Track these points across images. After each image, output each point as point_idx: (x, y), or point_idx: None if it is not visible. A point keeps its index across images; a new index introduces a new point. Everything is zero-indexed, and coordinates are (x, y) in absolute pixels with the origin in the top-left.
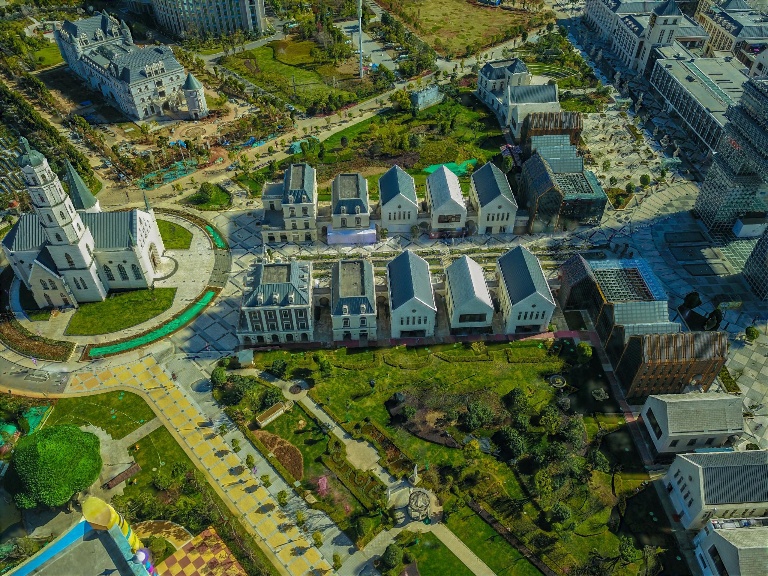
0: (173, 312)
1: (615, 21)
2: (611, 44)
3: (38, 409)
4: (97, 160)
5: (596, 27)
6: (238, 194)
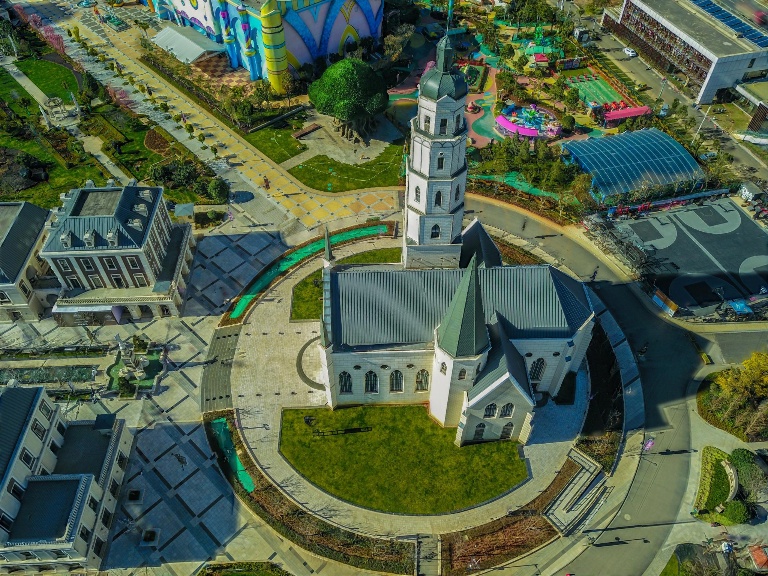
0: (290, 280)
1: None
2: None
3: None
4: None
5: None
6: None
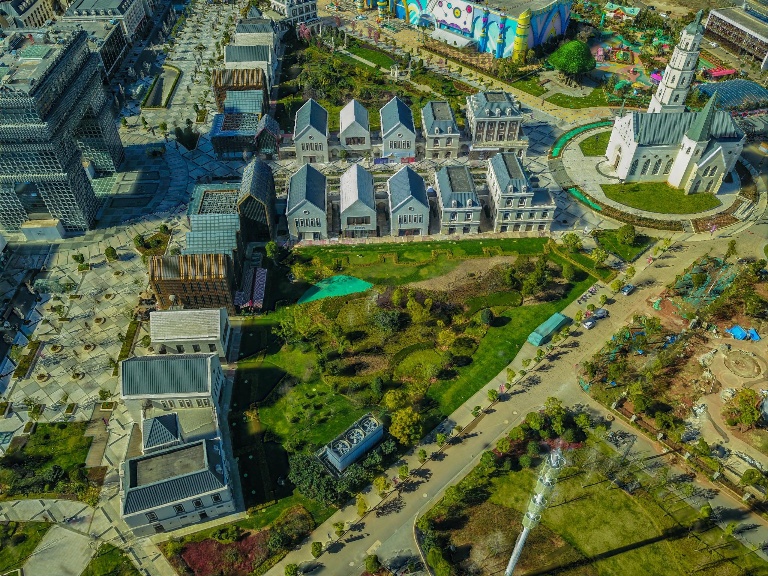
0: (575, 142)
1: None
2: None
3: None
4: None
5: None
6: None
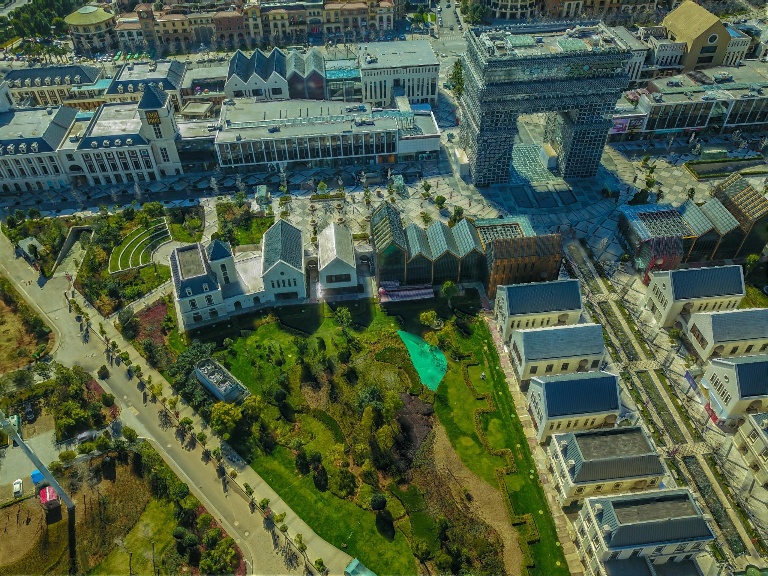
0: None
1: (62, 158)
2: (85, 182)
3: None
4: None
5: (18, 187)
6: None
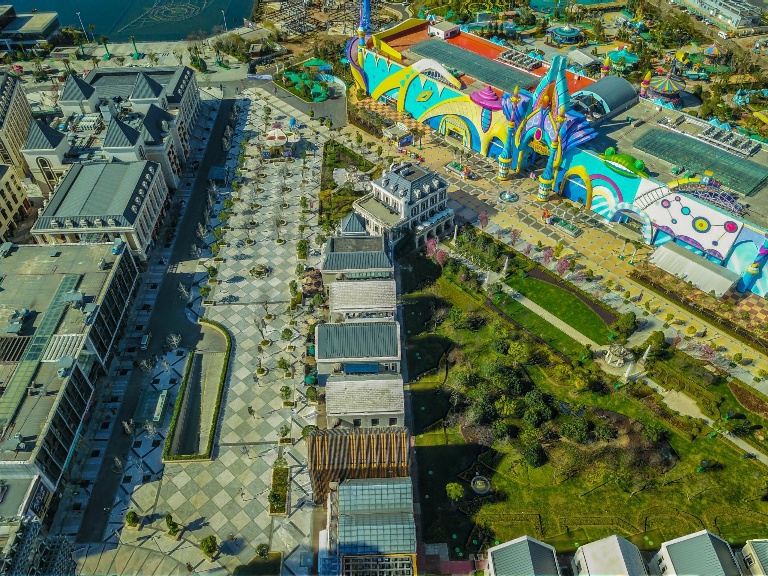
0: None
1: None
2: None
3: None
4: None
5: None
6: None
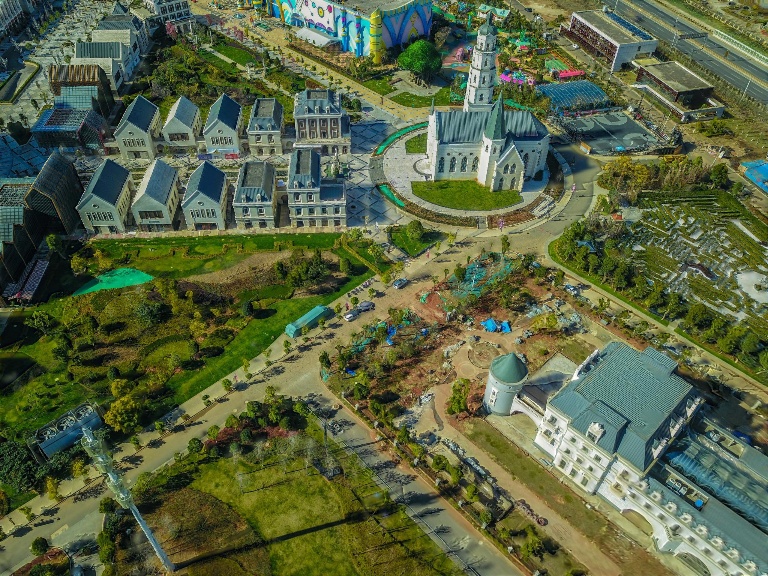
0: (402, 140)
1: None
2: None
3: (457, 99)
4: (594, 300)
5: None
6: (384, 245)
